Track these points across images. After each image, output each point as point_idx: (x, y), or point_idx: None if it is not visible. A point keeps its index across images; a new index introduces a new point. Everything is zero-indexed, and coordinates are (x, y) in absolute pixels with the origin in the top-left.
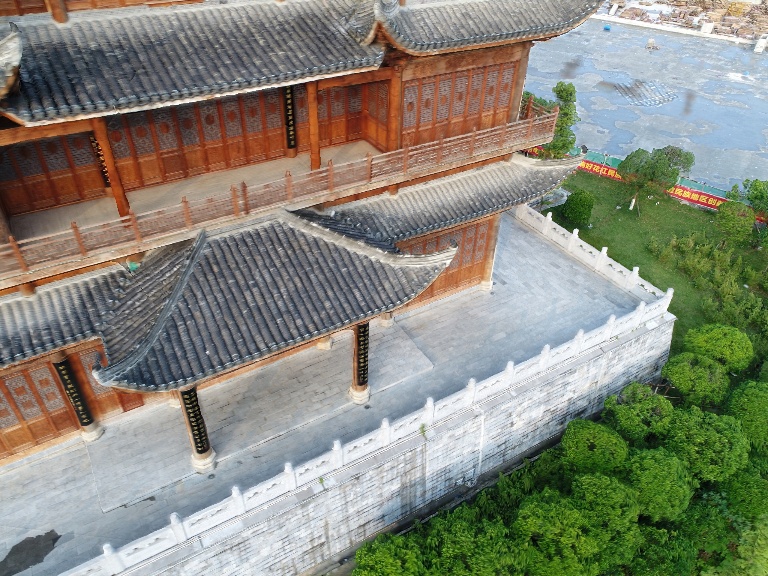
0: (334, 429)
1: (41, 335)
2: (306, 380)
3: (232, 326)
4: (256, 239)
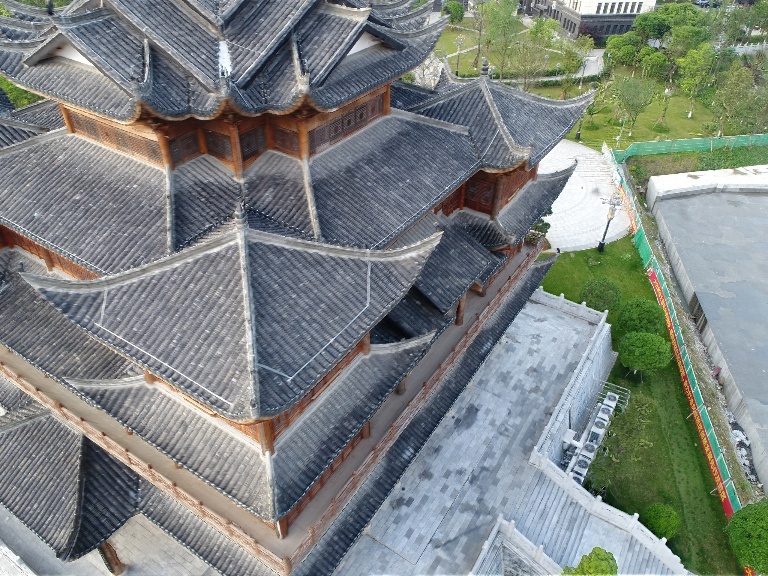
0: (85, 573)
1: (1, 392)
2: (127, 531)
3: (3, 467)
4: (64, 436)
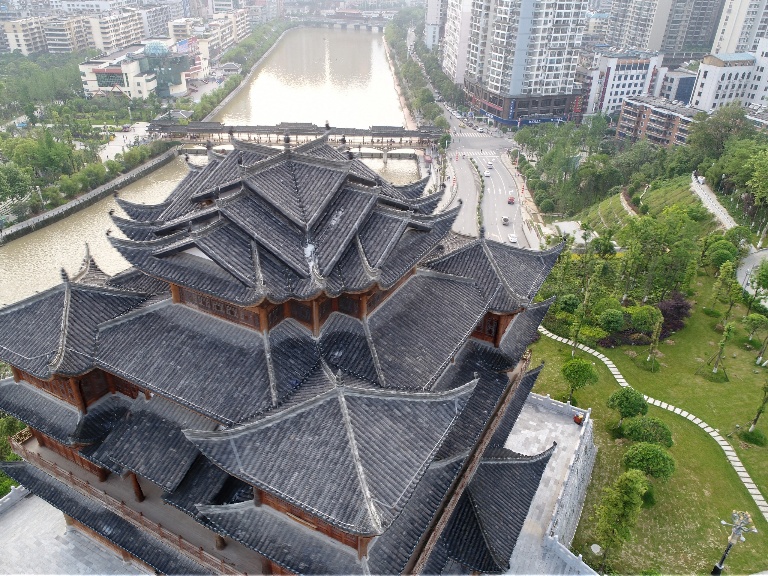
0: None
1: None
2: None
3: None
4: None
